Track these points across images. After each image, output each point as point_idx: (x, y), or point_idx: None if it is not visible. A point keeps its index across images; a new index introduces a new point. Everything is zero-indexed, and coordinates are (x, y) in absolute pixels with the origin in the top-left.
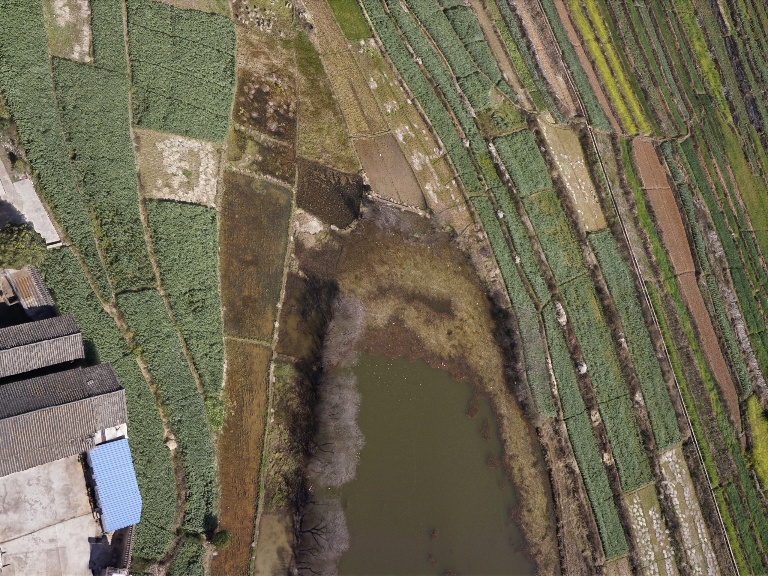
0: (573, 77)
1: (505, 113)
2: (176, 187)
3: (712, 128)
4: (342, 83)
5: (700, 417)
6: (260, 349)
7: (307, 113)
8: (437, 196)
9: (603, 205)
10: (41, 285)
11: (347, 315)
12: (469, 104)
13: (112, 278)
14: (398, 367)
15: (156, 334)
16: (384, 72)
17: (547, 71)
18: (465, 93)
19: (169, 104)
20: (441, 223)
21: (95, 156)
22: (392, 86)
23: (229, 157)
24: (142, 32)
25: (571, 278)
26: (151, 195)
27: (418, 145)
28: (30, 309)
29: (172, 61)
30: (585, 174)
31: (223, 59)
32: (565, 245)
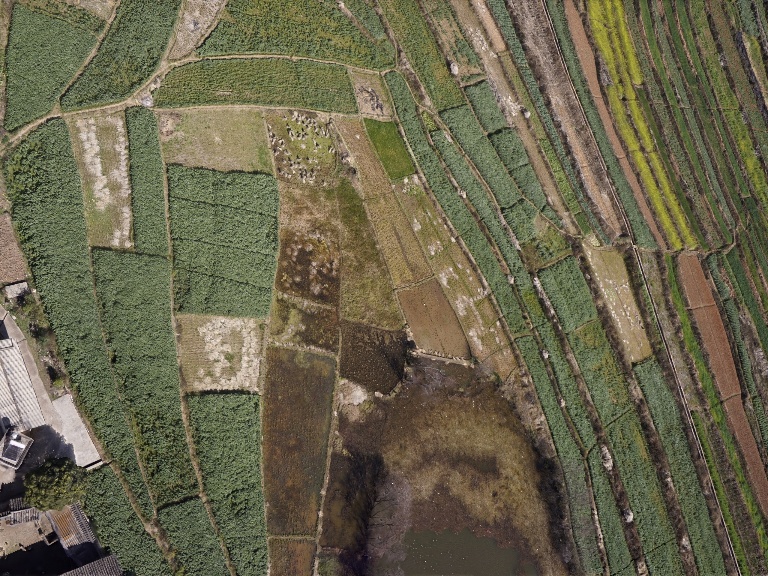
0: (618, 193)
1: (550, 241)
2: (218, 375)
3: (758, 234)
4: (386, 229)
5: (747, 556)
6: (304, 545)
7: (351, 269)
8: (481, 342)
9: (648, 331)
10: (82, 520)
11: (394, 502)
12: (514, 236)
13: (153, 491)
14: (443, 542)
15: (199, 549)
16: (428, 210)
17: (592, 189)
18: (510, 225)
19: (211, 283)
20: (486, 372)
21: (136, 356)
22: (436, 225)
23: (272, 331)
24: (184, 205)
25: (617, 416)
26: (193, 388)
27: (462, 287)
28: (70, 548)
29: (214, 234)
30: (630, 298)
31: (266, 223)
32: (610, 380)
